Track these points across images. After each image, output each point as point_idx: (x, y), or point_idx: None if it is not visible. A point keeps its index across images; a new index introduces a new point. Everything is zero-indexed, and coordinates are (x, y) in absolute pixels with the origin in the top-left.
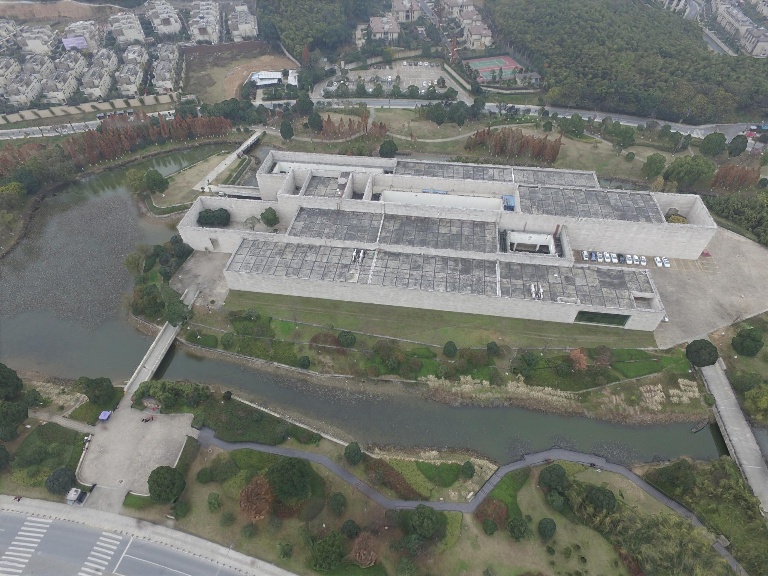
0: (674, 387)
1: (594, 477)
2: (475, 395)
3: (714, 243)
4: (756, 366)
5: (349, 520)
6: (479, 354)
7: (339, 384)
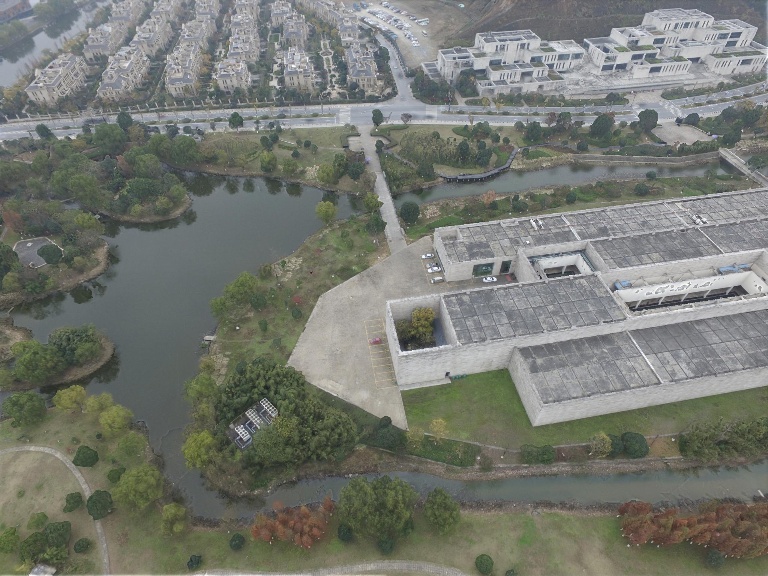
0: (419, 218)
1: (463, 171)
2: (539, 190)
3: (361, 365)
4: (361, 241)
5: (564, 127)
6: (551, 199)
7: (620, 180)
